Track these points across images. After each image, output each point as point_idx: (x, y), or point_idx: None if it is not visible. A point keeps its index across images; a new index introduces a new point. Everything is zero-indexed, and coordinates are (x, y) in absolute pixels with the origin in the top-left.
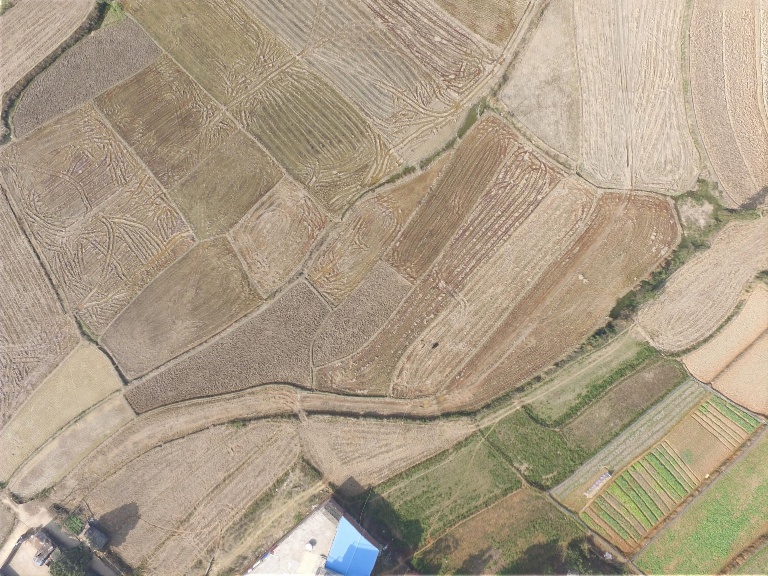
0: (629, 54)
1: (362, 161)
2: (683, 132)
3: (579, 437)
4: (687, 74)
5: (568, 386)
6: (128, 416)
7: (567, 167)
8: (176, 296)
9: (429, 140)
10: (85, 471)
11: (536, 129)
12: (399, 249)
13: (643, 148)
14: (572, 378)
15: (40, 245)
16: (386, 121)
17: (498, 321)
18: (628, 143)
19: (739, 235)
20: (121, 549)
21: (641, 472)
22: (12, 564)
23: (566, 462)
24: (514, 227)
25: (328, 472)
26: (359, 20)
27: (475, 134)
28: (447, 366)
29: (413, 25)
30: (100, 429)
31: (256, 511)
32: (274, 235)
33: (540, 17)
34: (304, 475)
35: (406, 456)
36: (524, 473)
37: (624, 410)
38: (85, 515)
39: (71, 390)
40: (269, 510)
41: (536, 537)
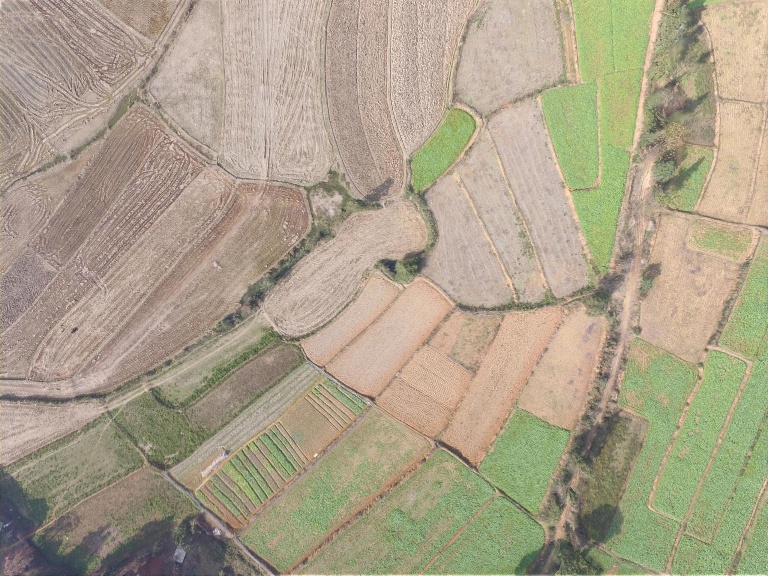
0: (272, 49)
1: (16, 150)
2: (318, 125)
3: (201, 418)
4: (322, 69)
5: (195, 369)
6: None
7: (210, 158)
8: None
9: (81, 130)
10: None
11: (181, 120)
12: (46, 236)
13: (280, 140)
14: (200, 362)
15: None
16: (40, 111)
17: (136, 307)
18: (266, 135)
19: (362, 225)
20: None
21: (255, 452)
22: None
23: (187, 442)
24: (156, 215)
25: None
26: (19, 11)
27: (124, 125)
28: (84, 350)
29: (70, 17)
30: None
31: None
32: None
33: (189, 11)
34: None
35: (37, 437)
36: (148, 453)
37: (244, 392)
38: None
39: None
40: None
41: (153, 514)
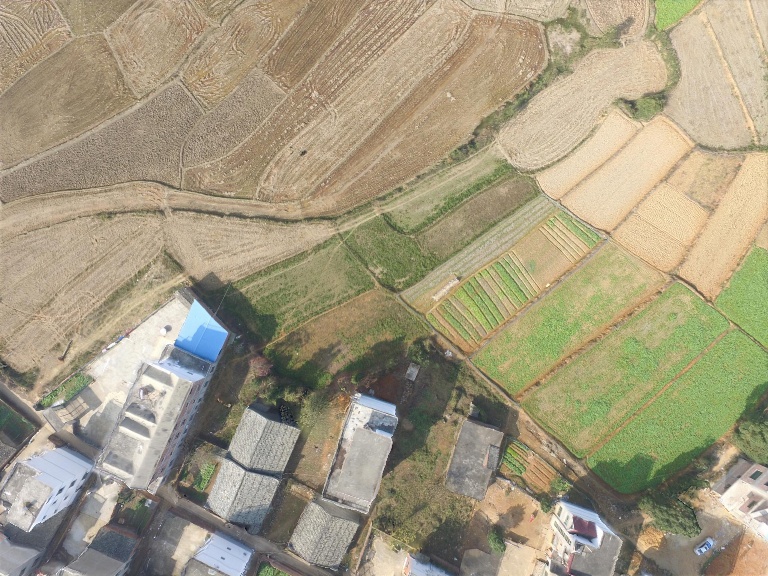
0: None
1: None
2: None
3: (433, 245)
4: None
5: (427, 197)
6: None
7: None
8: (49, 90)
9: None
10: None
11: None
12: (275, 57)
13: None
14: (432, 190)
15: None
16: None
17: (366, 133)
18: None
19: (601, 62)
20: None
21: (487, 279)
22: None
23: (418, 267)
24: (389, 43)
25: (190, 267)
26: None
27: None
28: (313, 173)
29: None
30: None
31: (116, 299)
32: (152, 36)
33: None
34: (165, 267)
35: (266, 255)
36: (378, 276)
37: (477, 221)
38: None
39: None
40: (129, 299)
41: (383, 335)
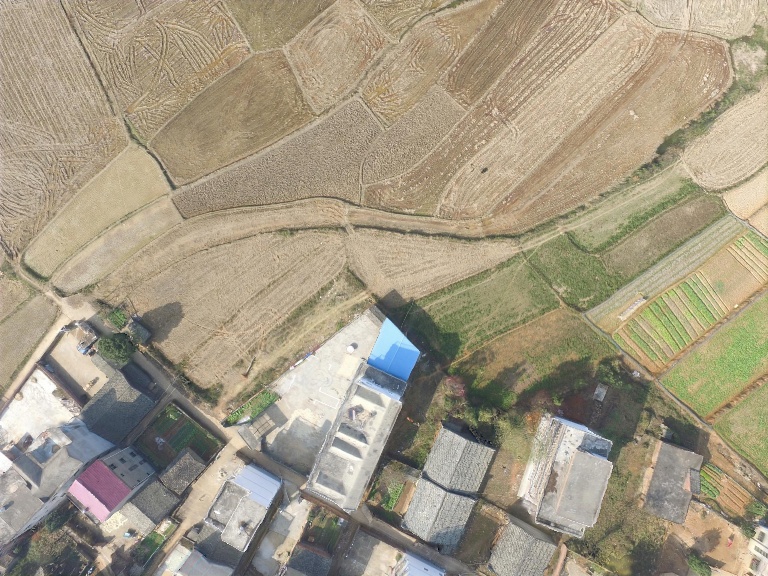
0: None
1: None
2: None
3: (618, 264)
4: None
5: (611, 216)
6: (175, 220)
7: (628, 4)
8: (228, 106)
9: None
10: (130, 270)
11: None
12: (455, 74)
13: None
14: (615, 209)
15: (91, 45)
16: None
17: (548, 151)
18: None
19: None
20: (163, 346)
21: (674, 299)
22: (53, 354)
23: (603, 287)
24: (571, 60)
25: (372, 284)
26: None
27: None
28: (495, 191)
29: None
30: (146, 231)
31: (299, 316)
32: (331, 52)
33: None
34: (348, 284)
35: (449, 273)
36: (562, 295)
37: (663, 241)
38: (128, 311)
39: (118, 191)
40: (312, 316)
41: (569, 354)
